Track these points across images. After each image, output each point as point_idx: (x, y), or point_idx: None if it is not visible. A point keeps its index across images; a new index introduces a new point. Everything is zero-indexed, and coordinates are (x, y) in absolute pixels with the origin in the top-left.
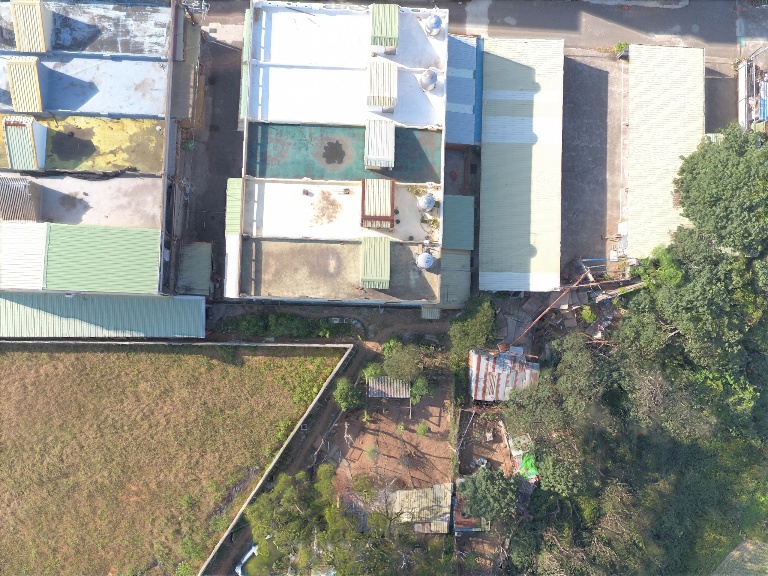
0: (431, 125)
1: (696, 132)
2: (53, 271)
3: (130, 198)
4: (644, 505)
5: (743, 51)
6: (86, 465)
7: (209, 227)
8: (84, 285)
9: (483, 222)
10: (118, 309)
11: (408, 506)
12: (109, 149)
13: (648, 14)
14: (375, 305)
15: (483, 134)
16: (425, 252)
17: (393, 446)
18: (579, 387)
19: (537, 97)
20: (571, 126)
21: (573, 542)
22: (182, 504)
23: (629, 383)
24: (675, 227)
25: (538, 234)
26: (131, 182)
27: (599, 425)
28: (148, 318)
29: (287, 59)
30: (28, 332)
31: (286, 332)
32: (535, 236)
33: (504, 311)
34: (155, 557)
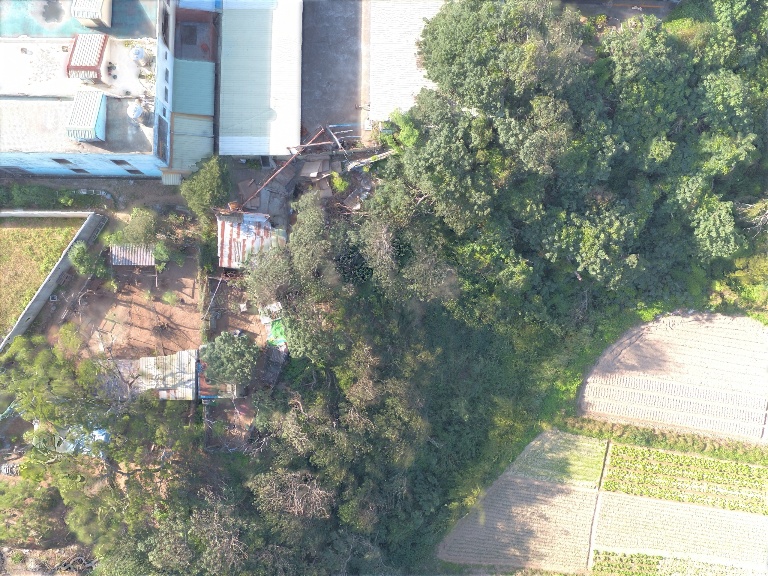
0: None
1: None
2: None
3: None
4: (404, 376)
5: None
6: None
7: None
8: None
9: (224, 88)
10: None
11: (152, 373)
12: None
13: None
14: (126, 177)
15: (224, 1)
16: (143, 107)
17: (146, 318)
18: (304, 242)
19: None
20: None
21: (327, 412)
22: None
23: (364, 241)
24: (419, 89)
25: (278, 98)
26: None
27: (366, 301)
28: None
29: None
30: None
31: (25, 199)
32: (275, 100)
33: (258, 182)
34: None
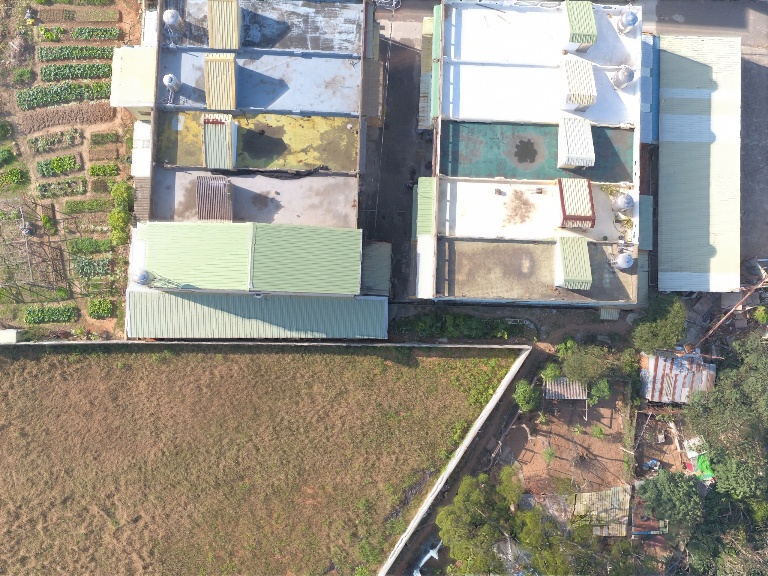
0: (624, 124)
1: None
2: (260, 271)
3: (322, 197)
4: None
5: None
6: (262, 468)
7: (380, 227)
8: (289, 286)
9: (662, 222)
10: (300, 310)
11: (587, 509)
12: (300, 147)
13: None
14: (547, 306)
15: (660, 133)
16: (619, 252)
17: (565, 448)
18: None
19: (715, 95)
20: None
21: (747, 545)
22: (359, 507)
23: None
24: None
25: (717, 234)
26: (323, 181)
27: (763, 427)
28: (330, 319)
29: (477, 56)
30: (210, 333)
31: (466, 333)
32: (714, 236)
33: None
34: (332, 561)
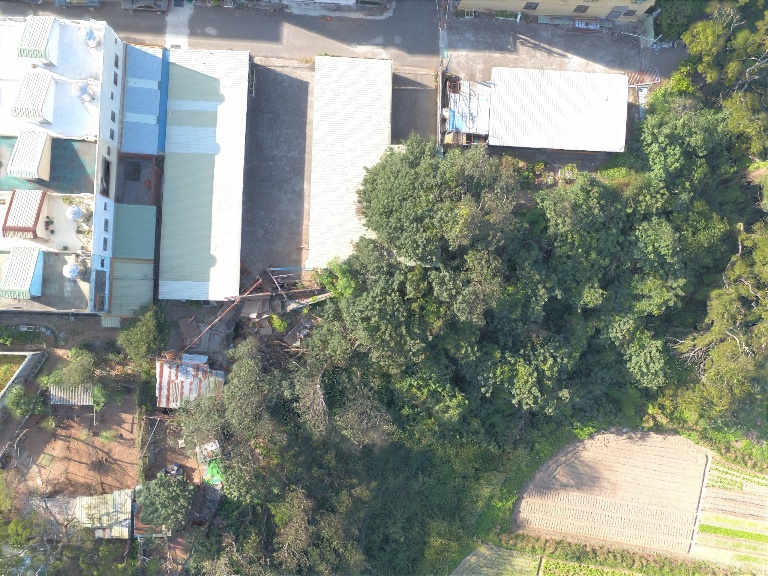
0: (87, 136)
1: (382, 143)
2: None
3: None
4: (339, 511)
5: (445, 62)
6: None
7: None
8: None
9: (164, 231)
10: None
11: (88, 512)
12: None
13: (351, 25)
14: (66, 313)
15: (167, 144)
16: (80, 262)
17: (85, 452)
18: (238, 396)
19: (221, 108)
20: (270, 136)
21: (262, 548)
22: None
23: (298, 392)
24: (357, 237)
25: (218, 244)
26: None
27: (305, 432)
28: None
29: None
30: None
31: None
32: (215, 246)
33: (198, 319)
34: None
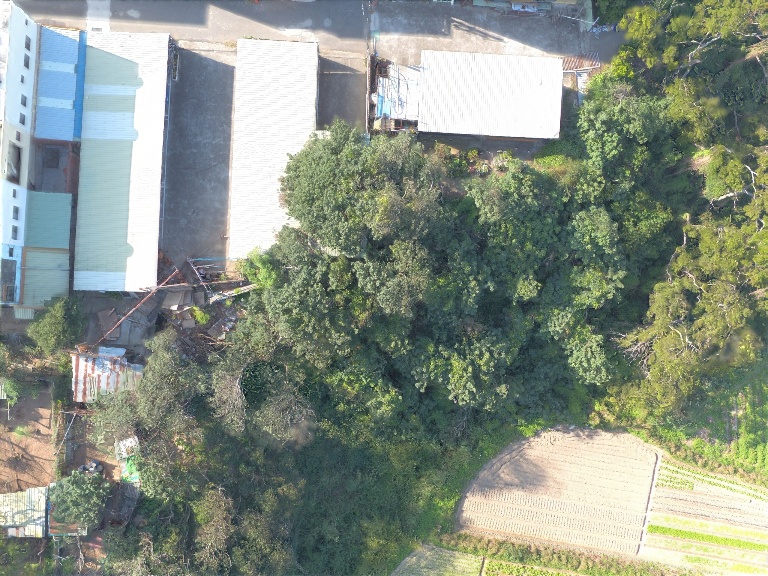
0: None
1: (306, 129)
2: None
3: None
4: (264, 510)
5: (377, 46)
6: None
7: None
8: None
9: (80, 220)
10: None
11: (1, 510)
12: None
13: (279, 7)
14: None
15: (83, 130)
16: None
17: (1, 448)
18: (151, 390)
19: (139, 92)
20: (194, 122)
21: (183, 547)
22: None
23: (216, 386)
24: (280, 226)
25: (135, 233)
26: None
27: None
28: None
29: None
30: None
31: None
32: (132, 235)
33: (119, 311)
34: None
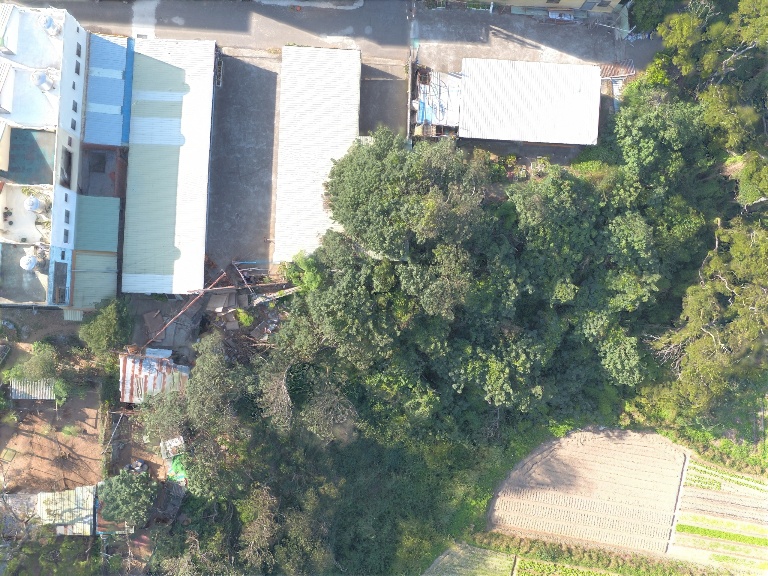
0: (47, 126)
1: (350, 135)
2: None
3: None
4: (306, 509)
5: None
6: None
7: None
8: None
9: (128, 224)
10: None
11: (49, 508)
12: None
13: (321, 15)
14: (30, 306)
15: (131, 135)
16: (39, 254)
17: (48, 448)
18: (200, 391)
19: (186, 98)
20: (237, 127)
21: (227, 545)
22: None
23: (262, 387)
24: (324, 230)
25: (182, 236)
26: None
27: (273, 428)
28: None
29: None
30: None
31: None
32: (179, 238)
33: (164, 313)
34: None
